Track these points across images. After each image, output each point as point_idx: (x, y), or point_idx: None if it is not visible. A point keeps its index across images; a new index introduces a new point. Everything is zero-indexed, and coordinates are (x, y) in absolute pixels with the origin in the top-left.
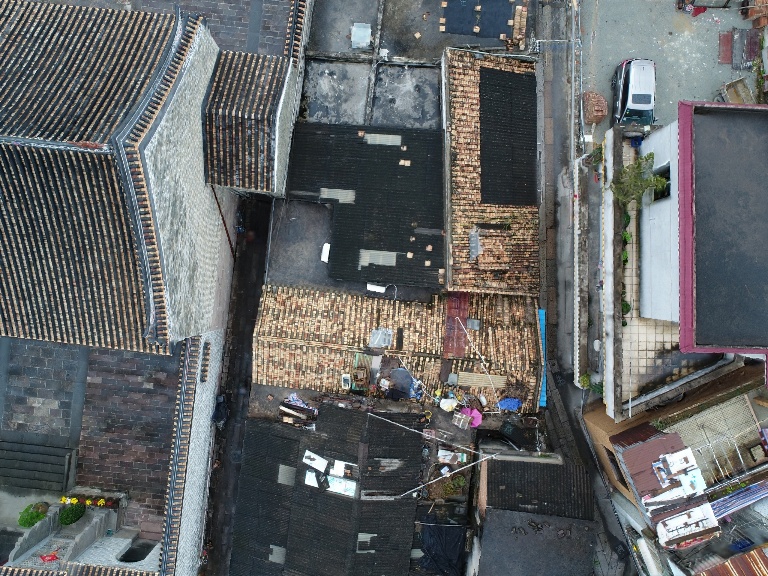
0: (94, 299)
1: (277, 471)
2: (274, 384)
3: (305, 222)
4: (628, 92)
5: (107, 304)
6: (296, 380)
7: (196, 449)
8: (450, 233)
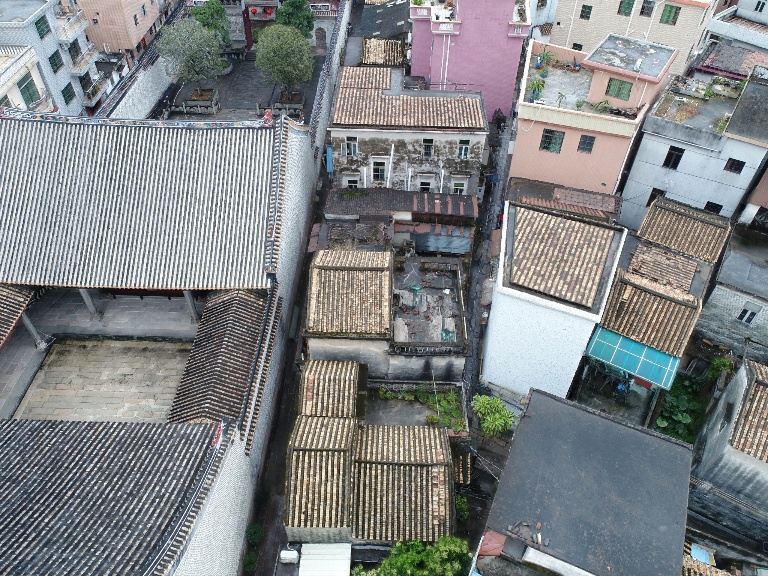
0: None
1: None
2: (373, 3)
3: None
4: None
5: None
6: (380, 1)
7: (345, 14)
8: None
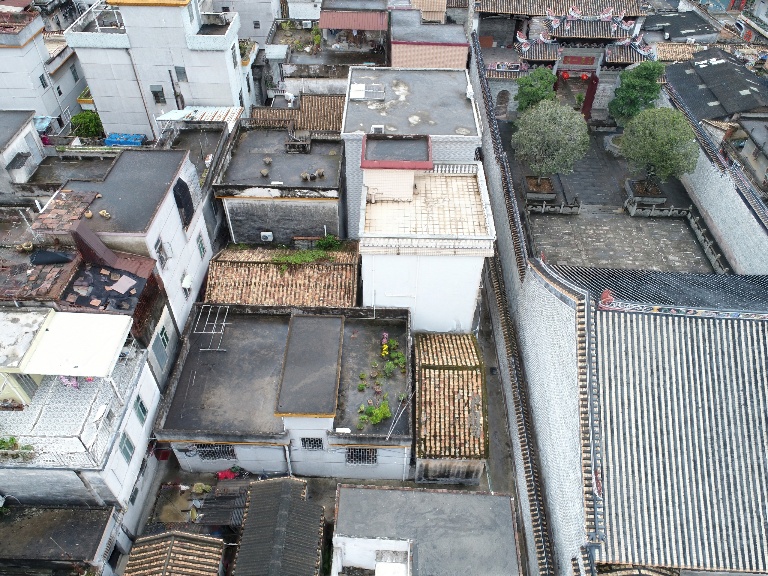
0: (619, 0)
1: (685, 72)
2: (667, 60)
3: (653, 34)
4: (741, 25)
5: (623, 1)
6: (676, 57)
7: None
8: (713, 19)
